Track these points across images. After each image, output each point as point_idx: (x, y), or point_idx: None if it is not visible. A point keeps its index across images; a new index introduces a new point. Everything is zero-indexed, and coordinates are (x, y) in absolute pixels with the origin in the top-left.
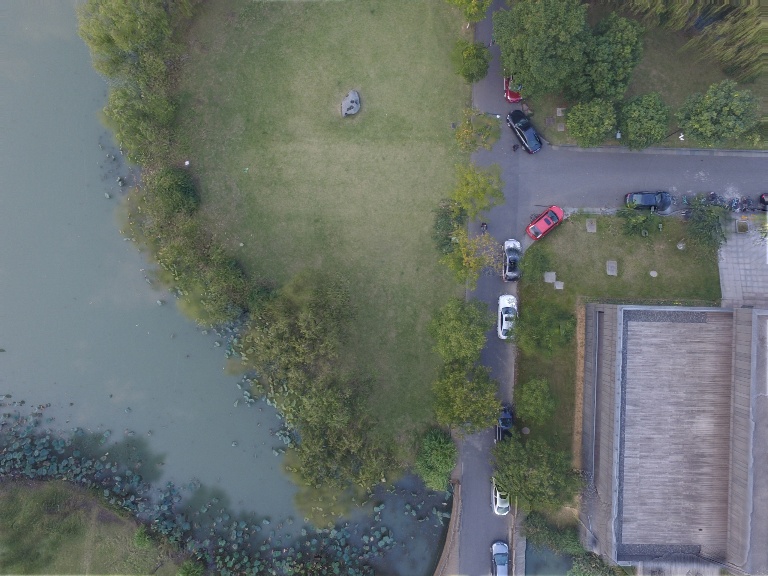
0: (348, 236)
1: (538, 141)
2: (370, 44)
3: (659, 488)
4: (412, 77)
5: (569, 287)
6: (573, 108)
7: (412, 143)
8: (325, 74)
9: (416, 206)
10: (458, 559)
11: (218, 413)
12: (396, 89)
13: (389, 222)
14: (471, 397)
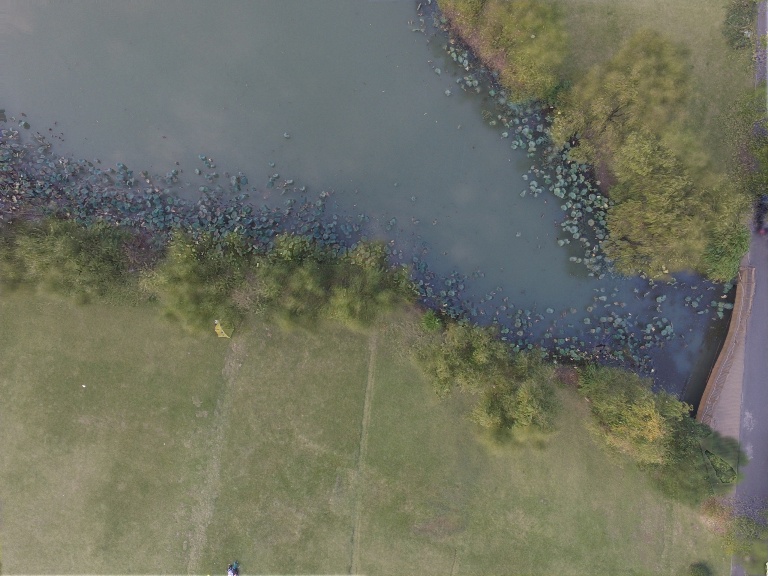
0: (640, 29)
1: None
2: None
3: None
4: None
5: None
6: None
7: None
8: None
9: (707, 2)
10: (744, 345)
11: (503, 204)
12: None
13: (681, 17)
14: (761, 187)
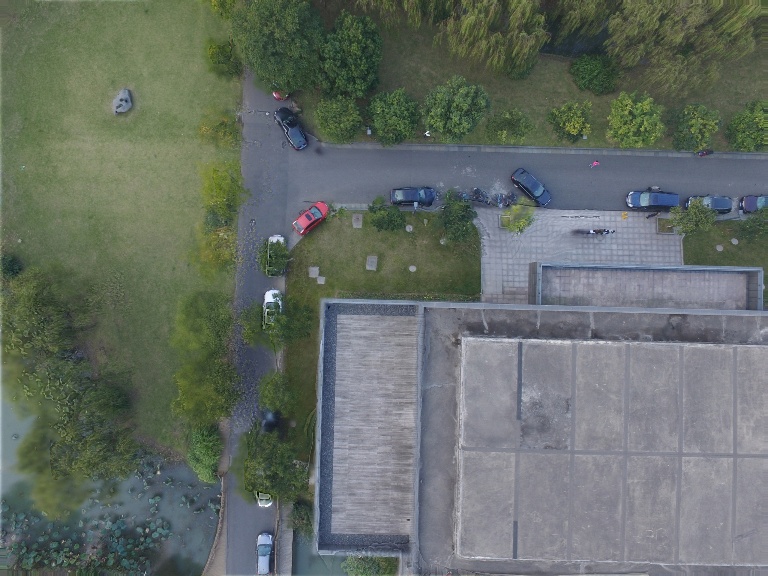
0: (121, 232)
1: (304, 138)
2: (144, 43)
3: (368, 479)
4: (184, 75)
5: (329, 282)
6: (318, 105)
7: (183, 140)
8: (99, 73)
9: (187, 202)
10: (225, 550)
11: None
12: (168, 87)
13: (161, 218)
14: (237, 390)
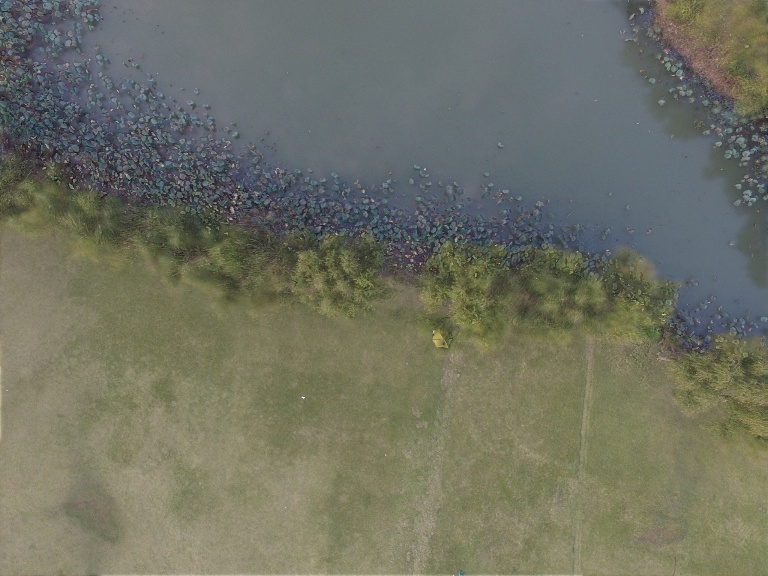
0: None
1: None
2: None
3: None
4: None
5: None
6: None
7: None
8: None
9: None
10: None
11: (716, 213)
12: None
13: None
14: None
